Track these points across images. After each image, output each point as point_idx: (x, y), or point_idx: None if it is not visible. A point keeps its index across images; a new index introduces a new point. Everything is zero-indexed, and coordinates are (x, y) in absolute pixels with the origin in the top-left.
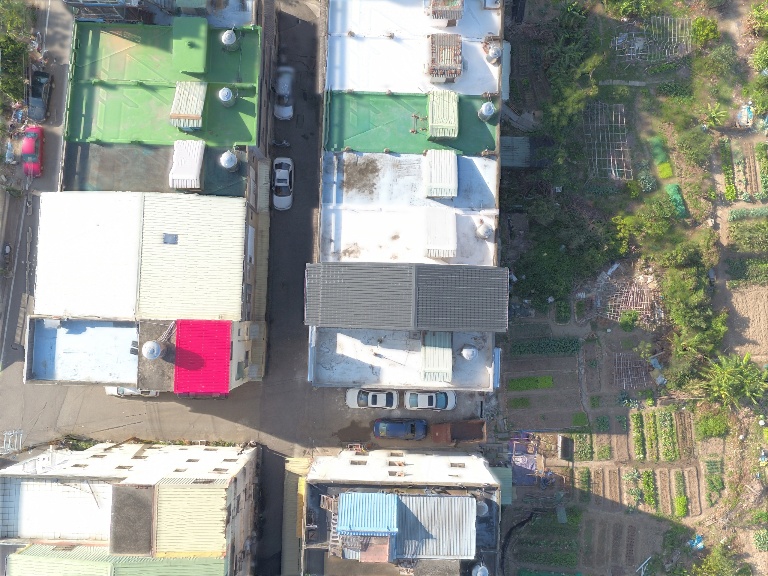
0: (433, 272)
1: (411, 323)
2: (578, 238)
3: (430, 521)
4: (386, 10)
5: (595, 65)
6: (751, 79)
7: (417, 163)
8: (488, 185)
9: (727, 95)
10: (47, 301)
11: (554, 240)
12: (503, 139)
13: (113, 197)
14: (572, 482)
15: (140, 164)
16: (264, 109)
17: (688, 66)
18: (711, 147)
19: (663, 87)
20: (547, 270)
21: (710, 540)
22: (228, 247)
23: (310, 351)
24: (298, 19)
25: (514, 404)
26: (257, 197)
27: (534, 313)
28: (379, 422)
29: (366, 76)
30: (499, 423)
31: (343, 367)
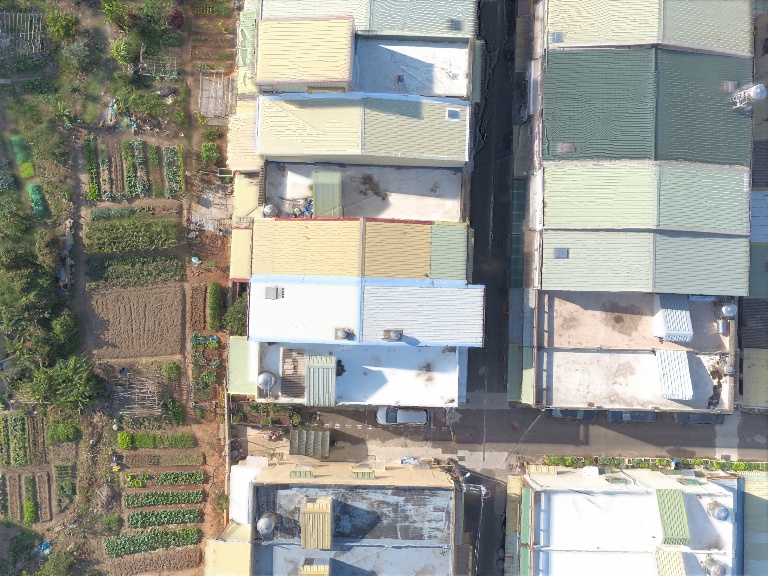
0: None
1: None
2: None
3: None
4: None
5: None
6: None
7: None
8: None
9: (96, 92)
10: None
11: None
12: None
13: None
14: None
15: None
16: None
17: (56, 63)
18: (78, 146)
19: (27, 85)
20: None
21: (59, 546)
22: None
23: None
24: None
25: None
26: None
27: None
28: None
29: None
30: None
31: None
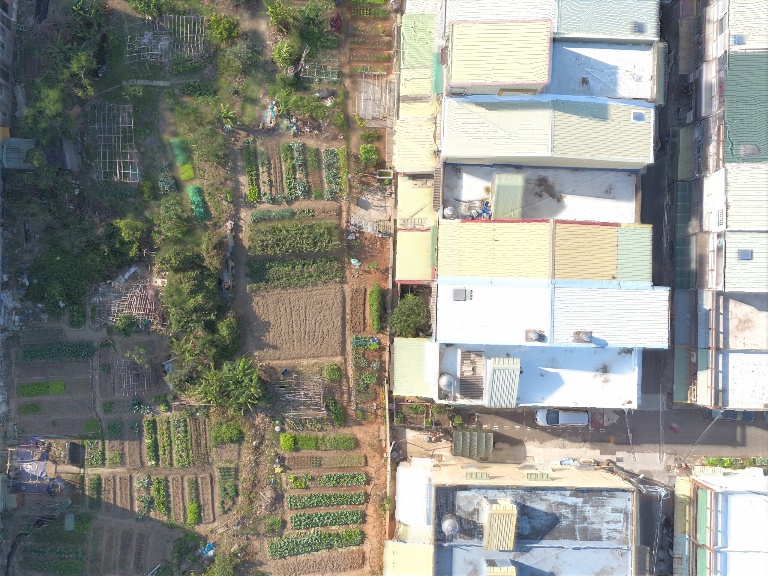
0: None
1: None
2: (78, 242)
3: None
4: None
5: (83, 65)
6: None
7: None
8: None
9: (254, 95)
10: None
11: (66, 244)
12: (11, 141)
13: None
14: (82, 489)
15: None
16: None
17: (214, 65)
18: (237, 148)
19: (187, 87)
20: (58, 274)
21: (222, 548)
22: None
23: None
24: None
25: (24, 410)
26: None
27: (47, 318)
28: None
29: None
30: (9, 429)
31: None
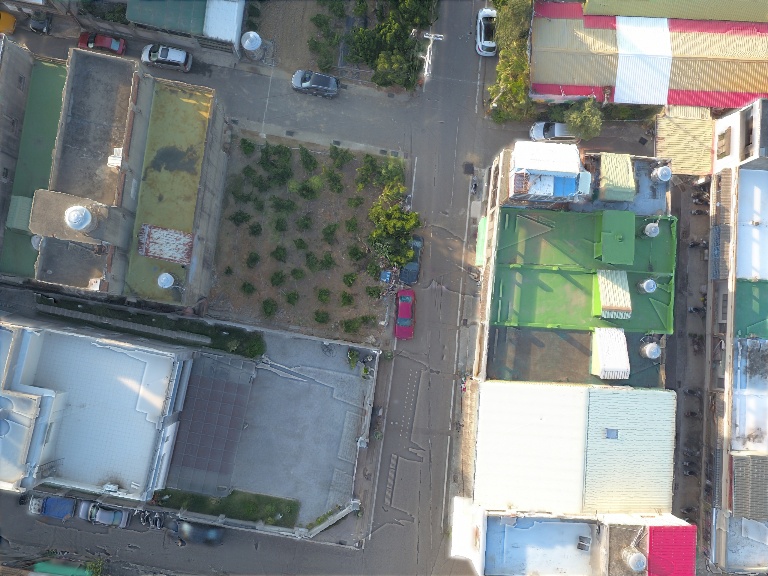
0: None
1: None
2: None
3: None
4: None
5: None
6: None
7: None
8: None
9: None
10: (487, 492)
11: None
12: None
13: (557, 391)
14: None
15: (555, 348)
16: None
17: None
18: None
19: None
20: None
21: None
22: (661, 440)
23: (715, 533)
24: None
25: None
26: None
27: None
28: None
29: (767, 264)
30: None
31: (748, 550)
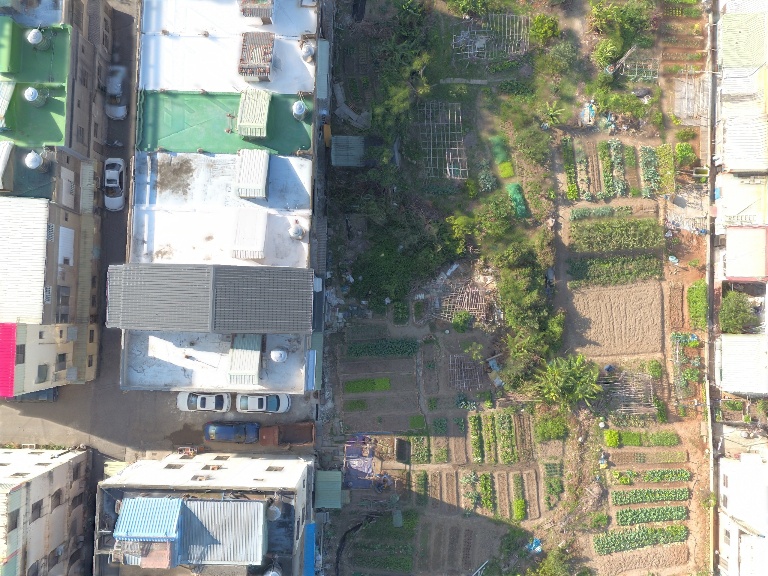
0: (232, 273)
1: (208, 325)
2: (411, 238)
3: (215, 526)
4: (202, 8)
5: (425, 63)
6: (594, 77)
7: (232, 163)
8: (304, 185)
9: (570, 93)
10: None
11: (391, 240)
12: (339, 138)
13: None
14: (409, 485)
15: None
16: (77, 109)
17: (531, 64)
18: (554, 146)
19: (505, 85)
20: (384, 271)
21: (548, 544)
22: (29, 249)
23: None
24: (133, 18)
25: (350, 406)
26: (80, 198)
27: (371, 314)
28: (209, 425)
29: (181, 75)
30: (335, 426)
31: (155, 370)
